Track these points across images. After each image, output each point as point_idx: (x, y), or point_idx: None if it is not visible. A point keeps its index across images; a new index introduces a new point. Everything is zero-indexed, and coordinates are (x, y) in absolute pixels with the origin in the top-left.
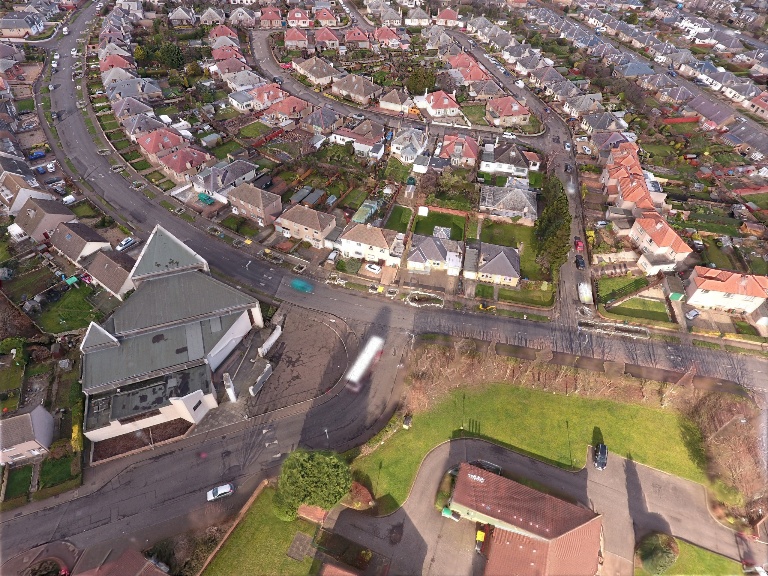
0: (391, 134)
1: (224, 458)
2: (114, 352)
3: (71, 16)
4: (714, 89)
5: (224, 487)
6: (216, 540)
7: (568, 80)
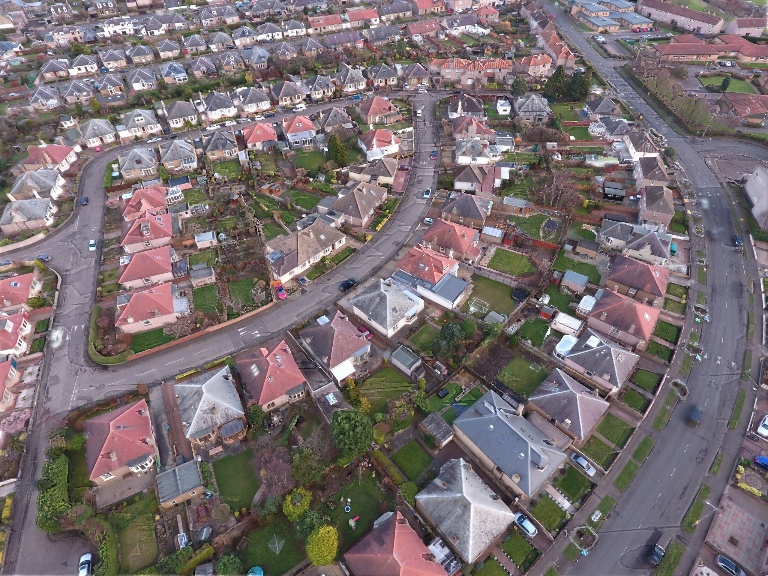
0: None
1: None
2: None
3: None
4: (279, 38)
5: None
6: None
7: (318, 75)
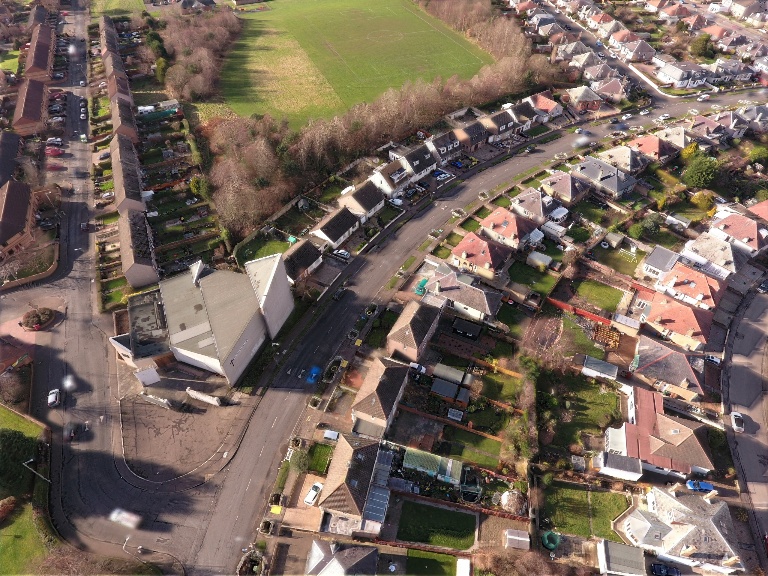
0: (704, 487)
1: (87, 392)
2: (190, 286)
3: (747, 89)
4: None
5: (53, 398)
6: (7, 403)
7: None
